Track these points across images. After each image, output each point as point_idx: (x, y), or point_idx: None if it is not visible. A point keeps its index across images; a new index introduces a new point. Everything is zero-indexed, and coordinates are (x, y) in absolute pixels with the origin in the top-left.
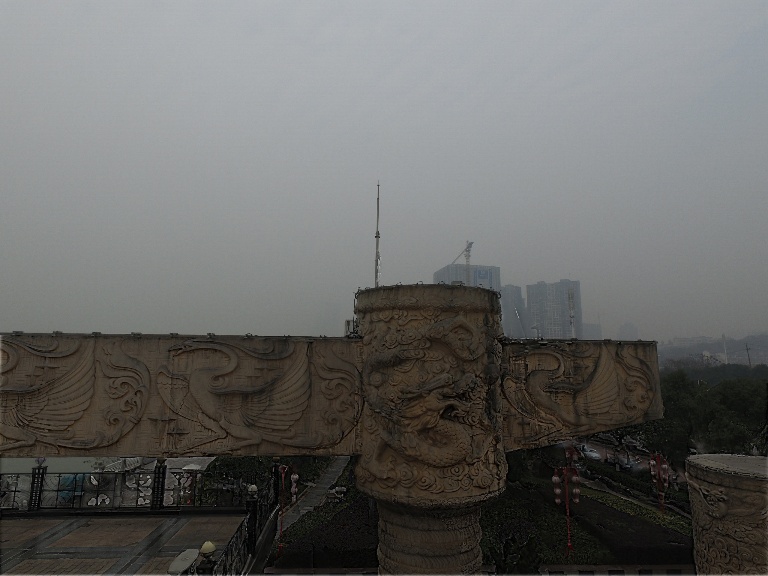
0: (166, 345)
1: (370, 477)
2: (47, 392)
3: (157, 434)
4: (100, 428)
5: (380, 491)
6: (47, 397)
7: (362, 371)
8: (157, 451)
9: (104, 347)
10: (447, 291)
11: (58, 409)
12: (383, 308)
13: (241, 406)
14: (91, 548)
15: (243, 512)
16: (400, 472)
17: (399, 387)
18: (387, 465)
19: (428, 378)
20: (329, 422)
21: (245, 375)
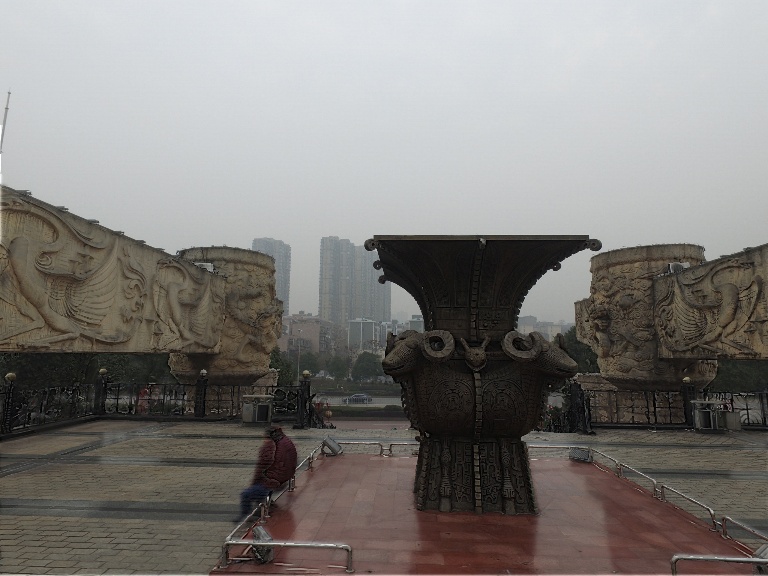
0: (156, 257)
1: (235, 363)
2: (87, 283)
3: (150, 333)
4: (118, 325)
5: (241, 371)
6: (87, 288)
7: (225, 299)
8: (149, 347)
9: (124, 247)
10: (272, 261)
11: (94, 302)
12: (249, 263)
13: (188, 315)
14: (87, 444)
15: (84, 421)
16: (256, 357)
17: (257, 310)
18: (250, 354)
19: (266, 307)
20: (214, 331)
21: (188, 292)
